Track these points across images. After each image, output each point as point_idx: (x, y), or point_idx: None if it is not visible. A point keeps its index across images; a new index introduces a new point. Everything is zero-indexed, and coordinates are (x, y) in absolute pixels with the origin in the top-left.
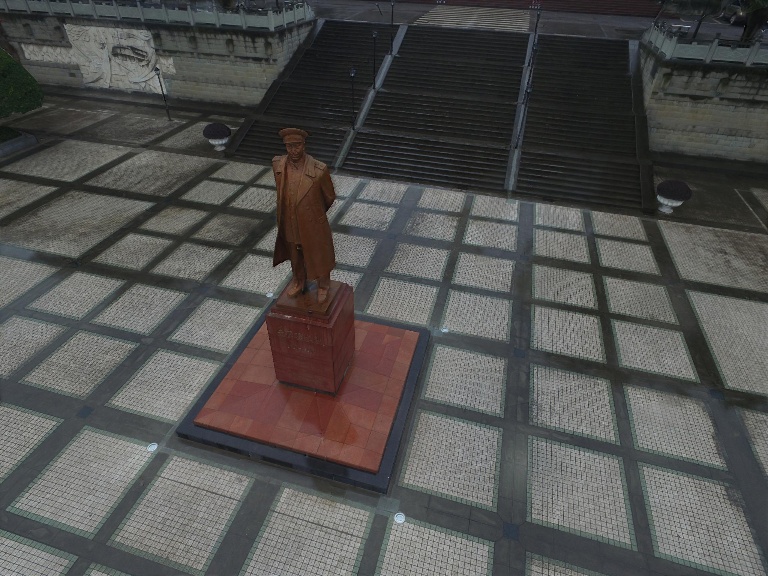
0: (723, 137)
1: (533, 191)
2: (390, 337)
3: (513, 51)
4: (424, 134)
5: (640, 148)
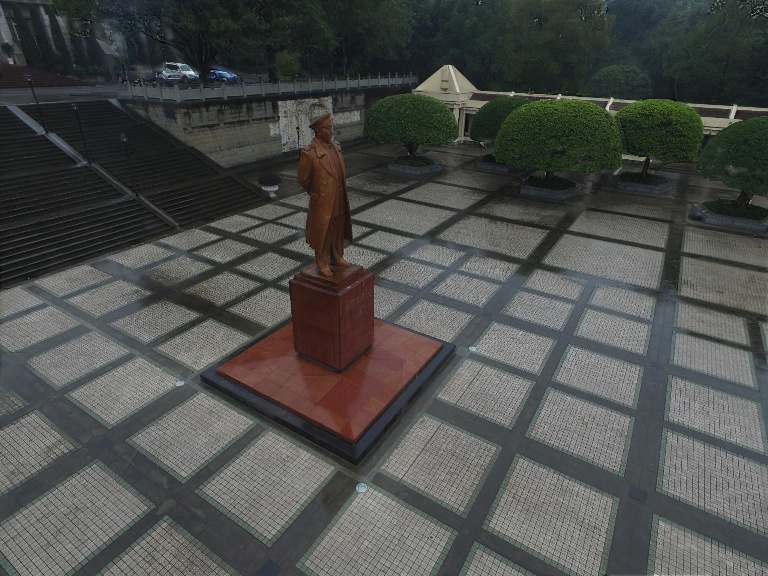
0: (238, 149)
1: (193, 219)
2: None
3: (7, 124)
4: (23, 220)
5: (215, 167)
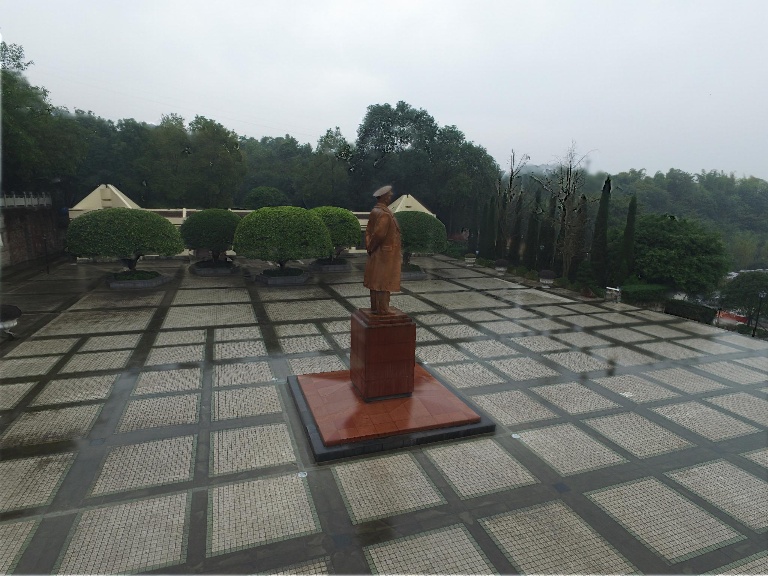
0: None
1: None
2: (316, 380)
3: None
4: None
5: None
